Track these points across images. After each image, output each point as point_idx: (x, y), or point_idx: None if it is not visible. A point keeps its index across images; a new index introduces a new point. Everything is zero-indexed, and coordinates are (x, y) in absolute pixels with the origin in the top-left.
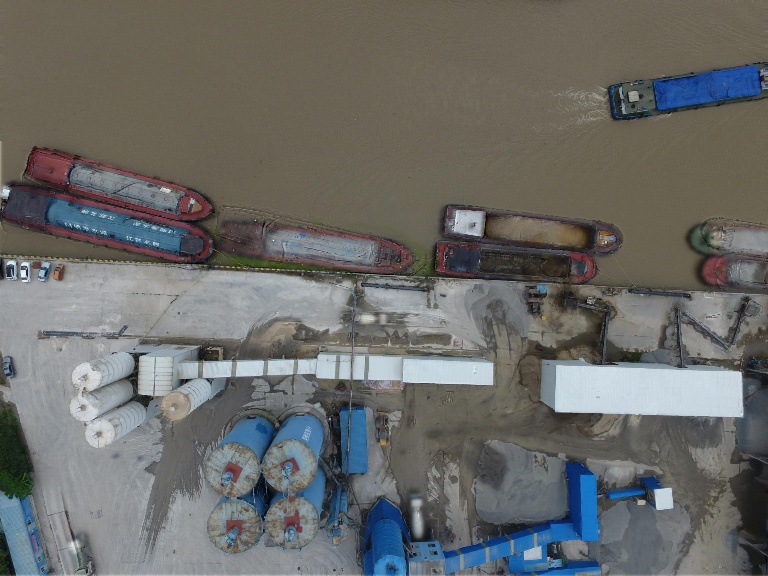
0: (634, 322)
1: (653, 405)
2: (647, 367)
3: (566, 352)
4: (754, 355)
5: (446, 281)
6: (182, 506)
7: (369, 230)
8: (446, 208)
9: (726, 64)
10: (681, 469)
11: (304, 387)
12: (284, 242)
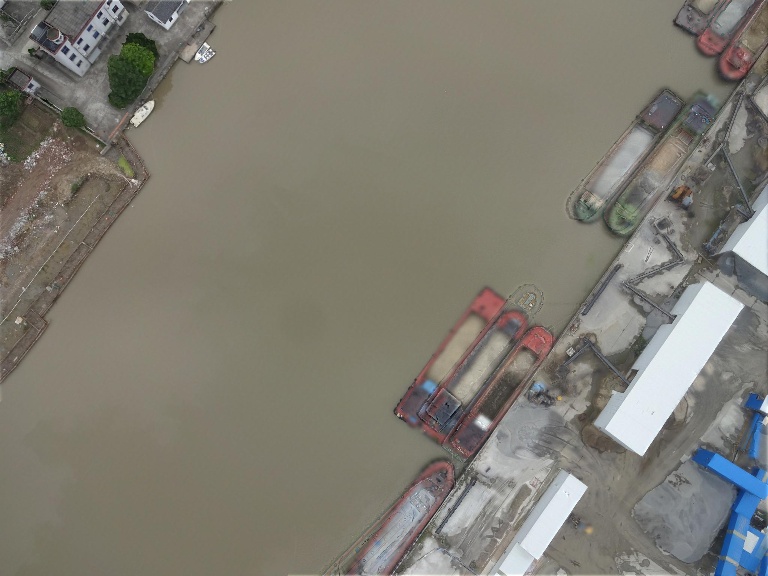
0: (611, 324)
1: (688, 372)
2: (654, 352)
3: (600, 398)
4: (703, 242)
5: (478, 459)
6: None
7: (396, 493)
8: (419, 417)
9: (450, 111)
10: (759, 365)
11: None
12: (361, 573)
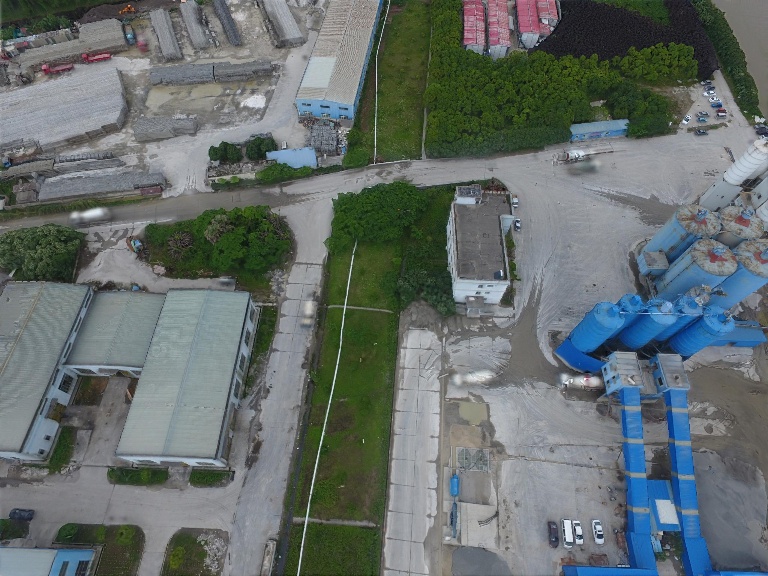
0: None
1: None
2: None
3: None
4: None
5: None
6: (630, 213)
7: None
8: None
9: None
10: None
11: (752, 300)
12: None
